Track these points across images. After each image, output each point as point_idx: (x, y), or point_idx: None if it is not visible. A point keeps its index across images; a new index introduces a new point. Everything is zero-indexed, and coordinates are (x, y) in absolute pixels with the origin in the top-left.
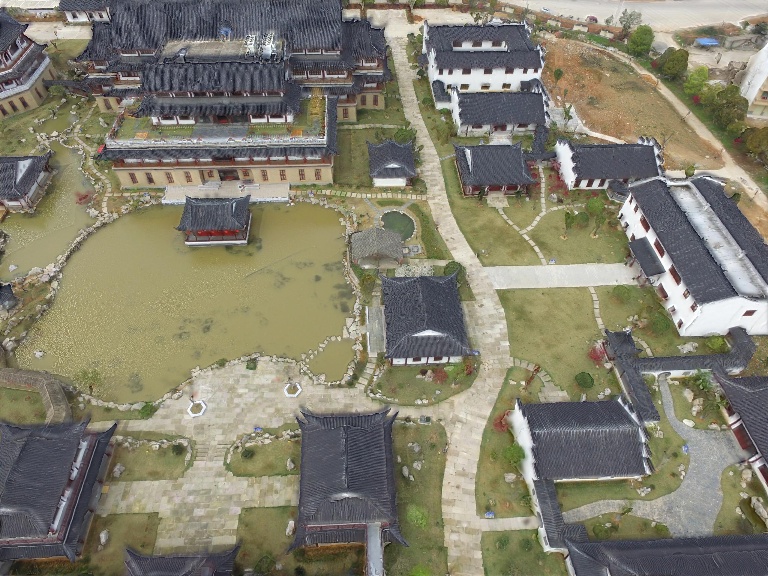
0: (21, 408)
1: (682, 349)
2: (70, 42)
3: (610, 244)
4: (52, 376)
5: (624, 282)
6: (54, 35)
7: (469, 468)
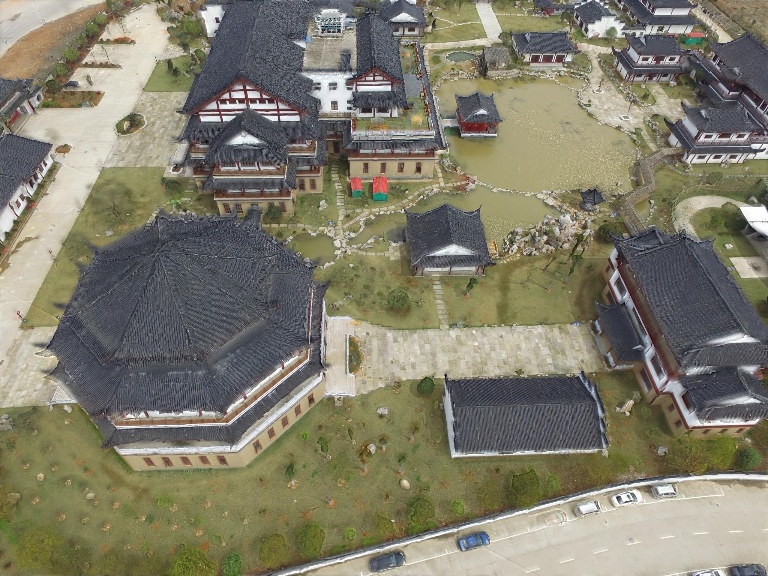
0: (661, 178)
1: (531, 1)
2: (48, 301)
3: (462, 4)
4: (640, 160)
5: (490, 6)
6: (0, 333)
7: (616, 50)
